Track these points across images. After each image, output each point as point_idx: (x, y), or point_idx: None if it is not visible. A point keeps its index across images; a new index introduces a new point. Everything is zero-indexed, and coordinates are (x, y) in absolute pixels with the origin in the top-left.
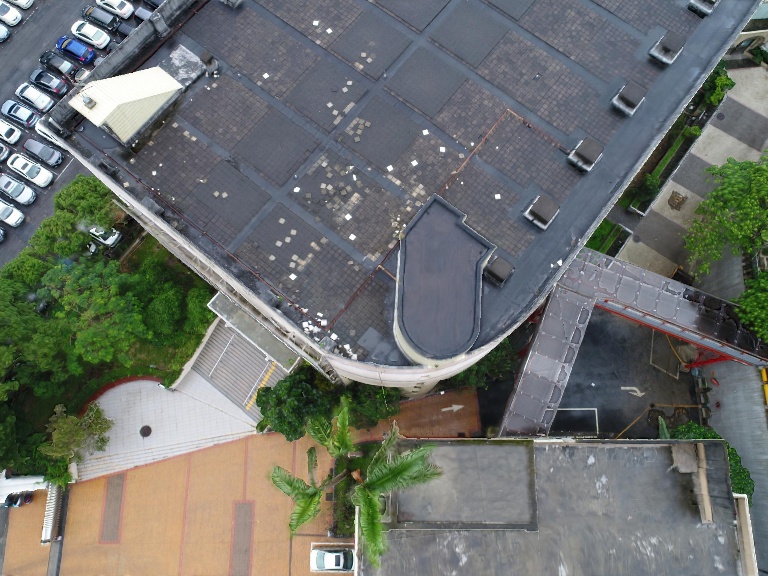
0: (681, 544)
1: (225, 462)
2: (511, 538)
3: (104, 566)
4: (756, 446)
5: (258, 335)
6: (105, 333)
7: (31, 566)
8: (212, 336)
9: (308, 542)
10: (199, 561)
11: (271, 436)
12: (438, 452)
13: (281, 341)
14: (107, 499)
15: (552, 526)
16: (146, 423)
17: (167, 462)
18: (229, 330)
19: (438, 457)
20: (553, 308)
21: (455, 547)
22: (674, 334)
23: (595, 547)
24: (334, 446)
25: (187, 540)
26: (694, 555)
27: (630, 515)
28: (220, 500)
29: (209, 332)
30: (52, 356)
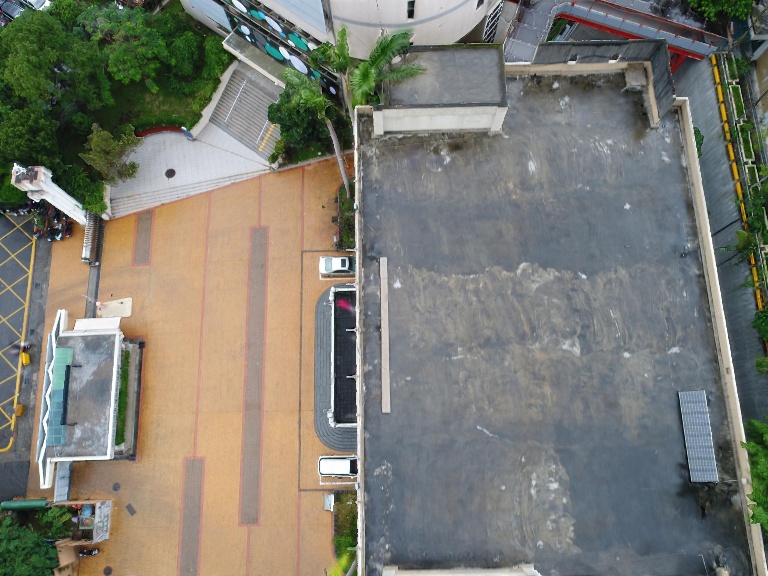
0: (633, 144)
1: (241, 196)
2: (488, 143)
3: (137, 284)
4: (709, 126)
5: (268, 65)
6: (134, 54)
7: (73, 287)
8: (227, 88)
9: (317, 257)
10: (221, 276)
11: (282, 174)
12: (423, 56)
13: (288, 58)
14: (138, 231)
15: (523, 133)
16: (170, 167)
17: (190, 199)
18: (242, 80)
19: (423, 59)
20: (527, 18)
21: (440, 151)
22: (634, 34)
23: (559, 147)
24: (335, 54)
25: (210, 260)
26: (644, 151)
27: (589, 124)
28: (238, 227)
29: (224, 82)
30: (89, 75)
